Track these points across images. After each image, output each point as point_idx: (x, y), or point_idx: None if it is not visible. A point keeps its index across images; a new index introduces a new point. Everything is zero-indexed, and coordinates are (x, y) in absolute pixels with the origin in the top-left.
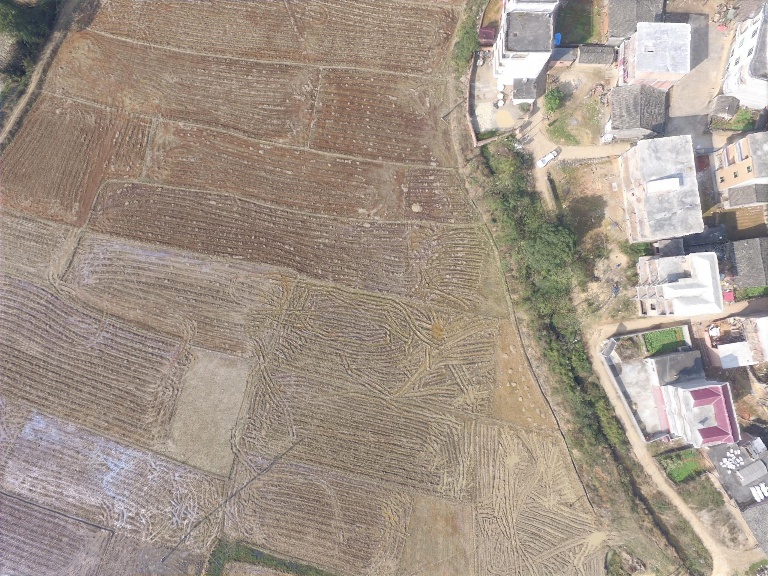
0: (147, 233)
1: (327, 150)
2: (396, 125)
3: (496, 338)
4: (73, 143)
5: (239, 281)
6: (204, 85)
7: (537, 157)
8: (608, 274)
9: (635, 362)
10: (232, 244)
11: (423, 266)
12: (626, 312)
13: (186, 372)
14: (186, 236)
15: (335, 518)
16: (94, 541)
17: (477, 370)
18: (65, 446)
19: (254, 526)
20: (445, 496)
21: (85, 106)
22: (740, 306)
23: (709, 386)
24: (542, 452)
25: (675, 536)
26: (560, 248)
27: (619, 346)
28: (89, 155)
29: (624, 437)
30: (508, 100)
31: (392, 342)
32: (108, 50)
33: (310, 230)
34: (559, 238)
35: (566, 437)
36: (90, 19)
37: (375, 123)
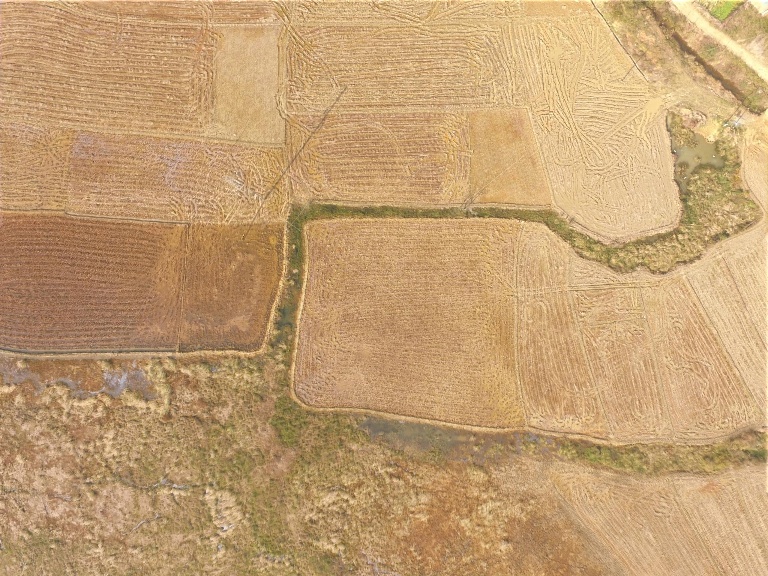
0: None
1: None
2: None
3: None
4: None
5: None
6: None
7: None
8: None
9: None
10: None
11: None
12: None
13: (215, 52)
14: None
15: (397, 155)
16: (173, 238)
17: None
18: (118, 155)
19: (322, 183)
20: (498, 105)
21: None
22: None
23: None
24: (583, 36)
25: (729, 80)
26: None
27: None
28: None
29: None
30: None
31: None
32: None
33: None
34: None
35: (604, 14)
36: None
37: None
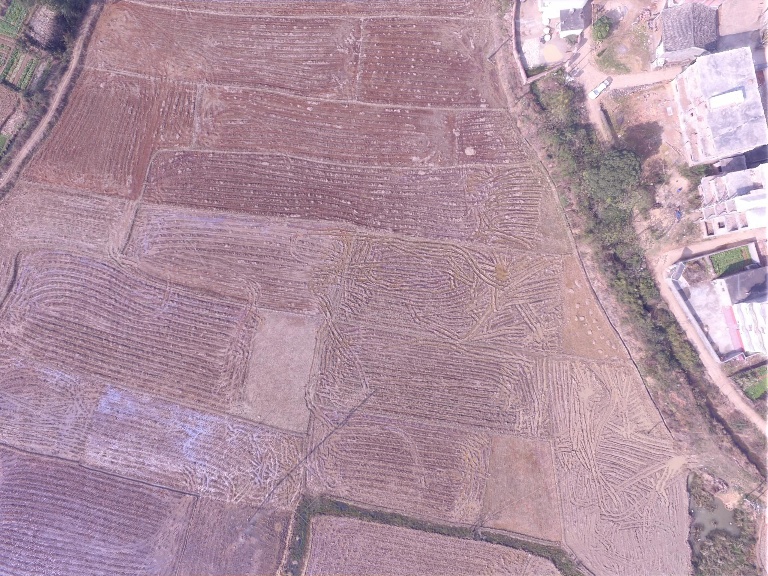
0: (203, 200)
1: (375, 101)
2: (442, 70)
3: (560, 274)
4: (120, 116)
5: (299, 240)
6: (246, 46)
7: (588, 89)
8: (670, 199)
9: (703, 285)
10: (288, 203)
11: (481, 209)
12: (691, 236)
13: (254, 334)
14: (242, 199)
15: (415, 465)
16: (180, 507)
17: (544, 307)
18: (142, 417)
19: (336, 479)
20: (523, 434)
21: (129, 78)
22: None
23: None
24: (615, 383)
25: (755, 453)
26: (627, 172)
27: (686, 270)
28: (137, 127)
29: (698, 359)
30: (554, 34)
31: (457, 287)
32: (146, 19)
33: (365, 183)
34: (625, 162)
35: (638, 366)
36: None
37: (421, 70)
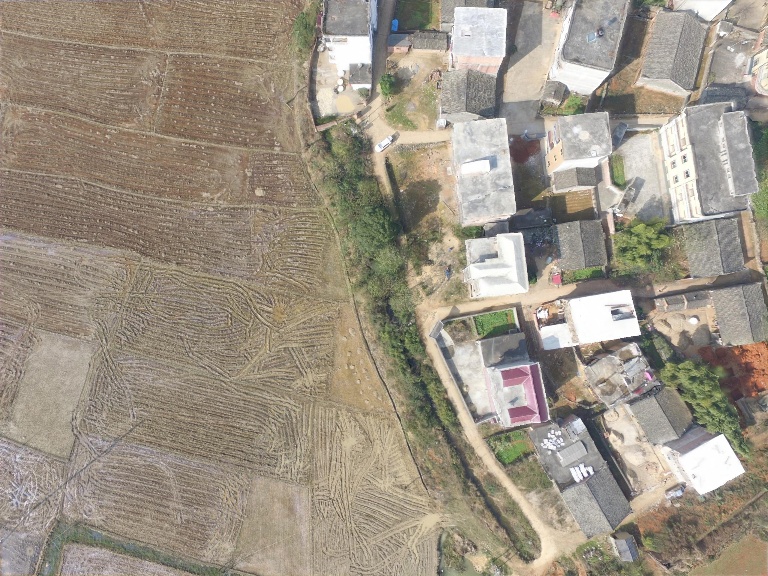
0: None
1: (173, 135)
2: (241, 110)
3: (335, 321)
4: None
5: (84, 264)
6: (53, 70)
7: (376, 142)
8: (441, 257)
9: (467, 345)
10: (77, 227)
11: (265, 250)
12: (458, 295)
13: (29, 354)
14: (32, 219)
15: (173, 500)
16: None
17: (316, 353)
18: None
19: (93, 508)
20: (282, 478)
21: None
22: (568, 289)
23: (520, 366)
24: (378, 434)
25: (506, 518)
26: (375, 229)
27: (452, 329)
28: None
29: (454, 419)
30: (348, 85)
31: (233, 325)
32: None
33: (154, 214)
34: (373, 219)
35: (402, 419)
36: None
37: (220, 108)
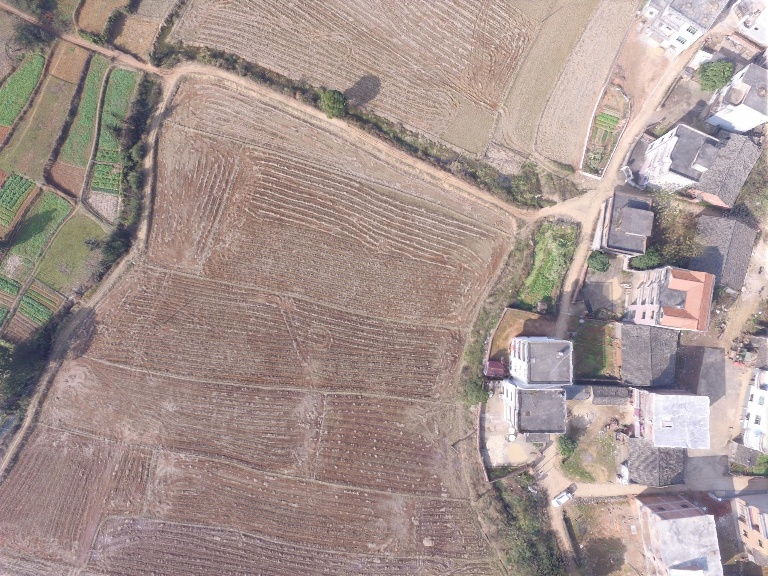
0: (149, 573)
1: (334, 481)
2: (404, 454)
3: None
4: (71, 478)
5: None
6: (205, 414)
7: (552, 494)
8: None
9: None
10: None
11: None
12: None
13: None
14: (190, 575)
15: None
16: None
17: None
18: None
19: None
20: None
21: (83, 438)
22: None
23: None
24: None
25: None
26: None
27: None
28: (88, 490)
29: None
30: (520, 434)
31: None
32: (105, 378)
33: (318, 567)
34: None
35: None
36: (86, 346)
37: (383, 452)
